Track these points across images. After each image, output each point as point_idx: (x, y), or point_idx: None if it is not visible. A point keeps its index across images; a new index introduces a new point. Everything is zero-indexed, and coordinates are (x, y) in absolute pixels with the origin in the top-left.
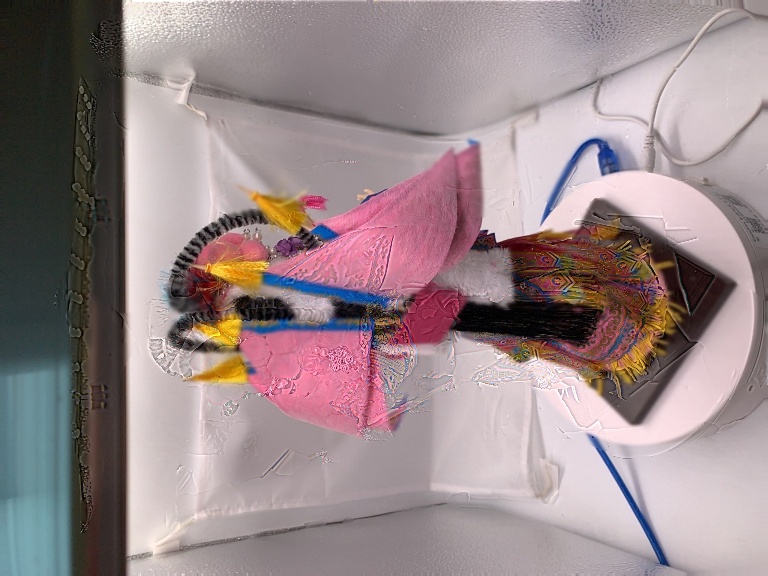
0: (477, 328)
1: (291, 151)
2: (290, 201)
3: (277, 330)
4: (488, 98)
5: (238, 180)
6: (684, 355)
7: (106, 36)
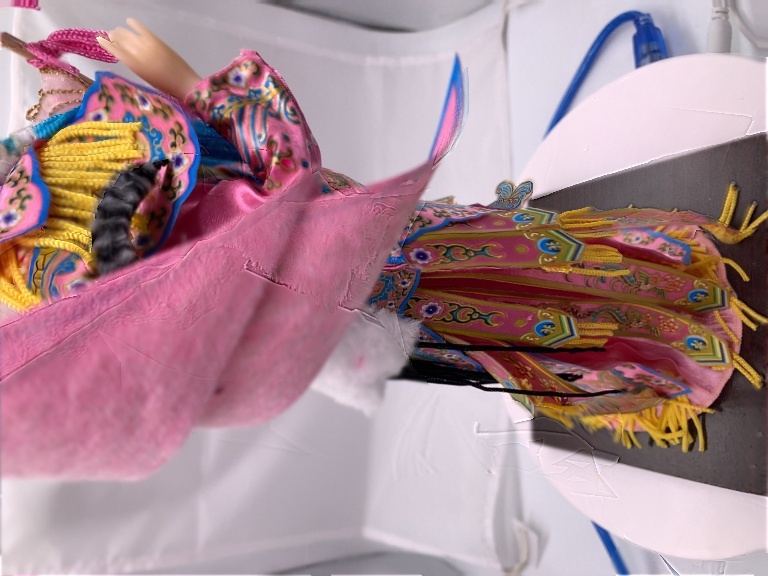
0: None
1: None
2: None
3: None
4: None
5: None
6: None
7: None
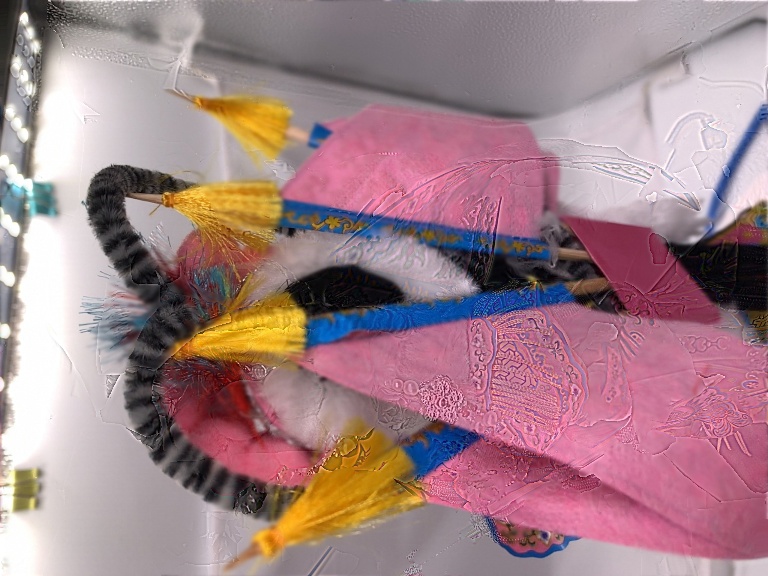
0: (767, 302)
1: (311, 144)
2: (313, 208)
3: (334, 346)
4: (555, 71)
5: (244, 183)
6: None
7: (68, 4)
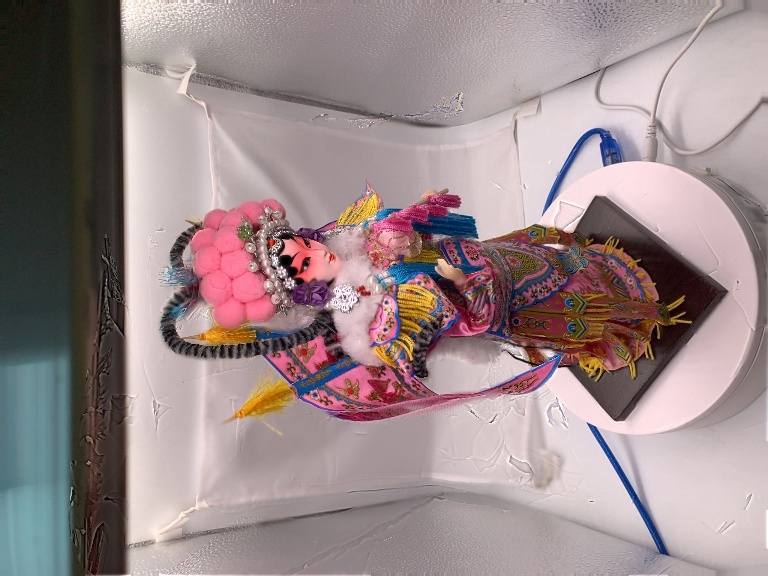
0: None
1: None
2: None
3: None
4: None
5: None
6: None
7: None
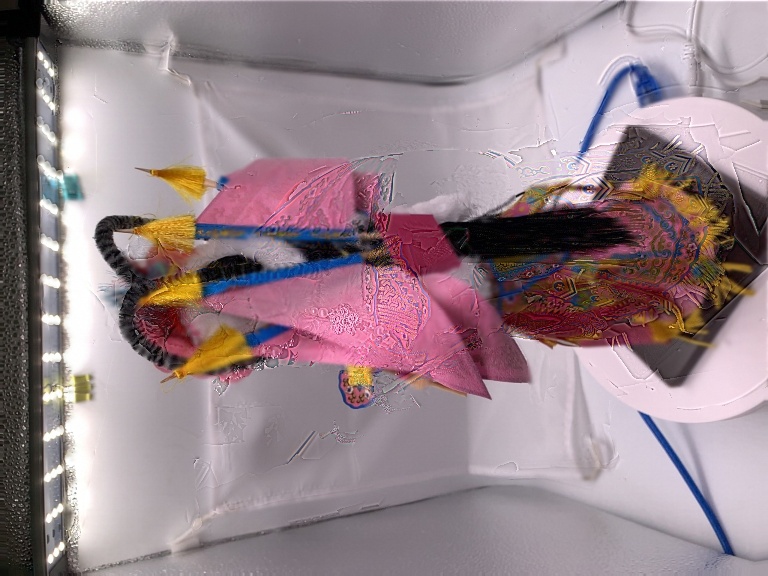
0: (494, 258)
1: (286, 108)
2: (291, 163)
3: (261, 289)
4: (499, 25)
5: (232, 146)
6: (754, 282)
7: (73, 3)
